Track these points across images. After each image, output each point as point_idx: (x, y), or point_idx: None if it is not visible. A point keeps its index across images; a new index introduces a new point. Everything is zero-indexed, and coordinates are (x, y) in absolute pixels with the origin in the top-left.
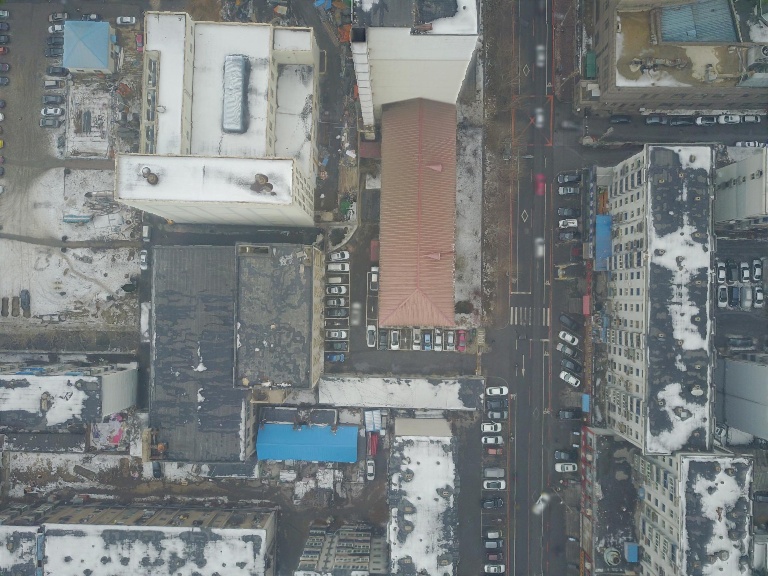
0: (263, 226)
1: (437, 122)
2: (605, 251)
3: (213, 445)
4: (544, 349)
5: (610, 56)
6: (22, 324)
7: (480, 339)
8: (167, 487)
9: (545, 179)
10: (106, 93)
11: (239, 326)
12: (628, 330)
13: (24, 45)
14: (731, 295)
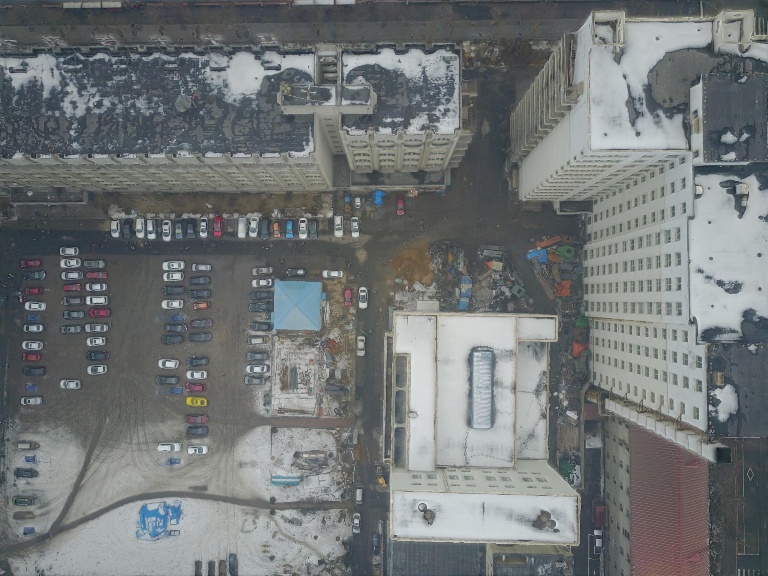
0: None
1: None
2: None
3: None
4: None
5: None
6: None
7: None
8: None
9: None
10: (312, 348)
11: None
12: None
13: (226, 298)
14: None
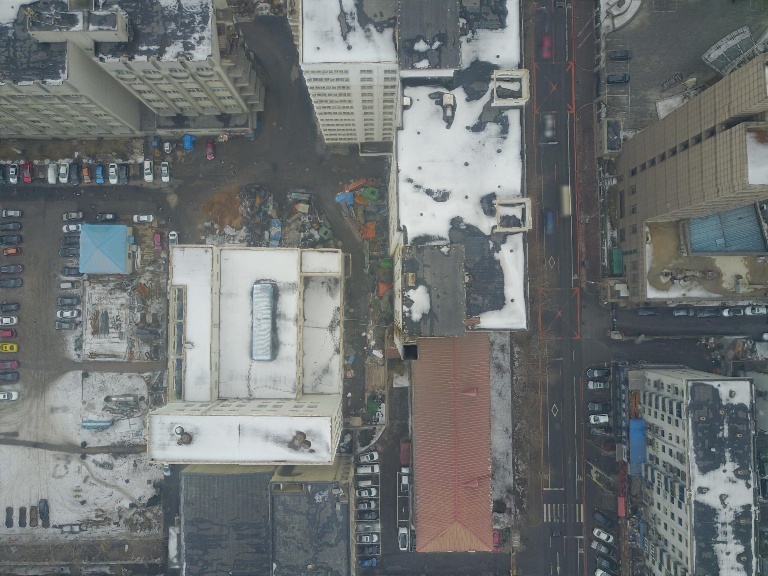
0: None
1: (470, 346)
2: (640, 457)
3: None
4: (578, 546)
5: (640, 265)
6: (41, 535)
7: (515, 542)
8: None
9: (574, 372)
10: (124, 293)
11: (275, 567)
12: (669, 553)
13: (37, 244)
14: (764, 489)
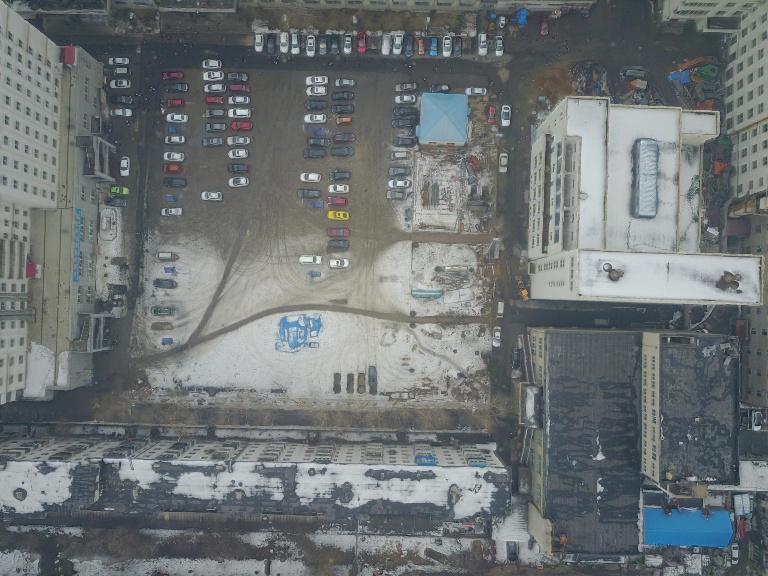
0: (620, 303)
1: None
2: None
3: (613, 536)
4: None
5: None
6: (369, 401)
7: None
8: (521, 570)
9: None
10: (454, 165)
11: (662, 419)
12: None
13: (368, 115)
14: None
